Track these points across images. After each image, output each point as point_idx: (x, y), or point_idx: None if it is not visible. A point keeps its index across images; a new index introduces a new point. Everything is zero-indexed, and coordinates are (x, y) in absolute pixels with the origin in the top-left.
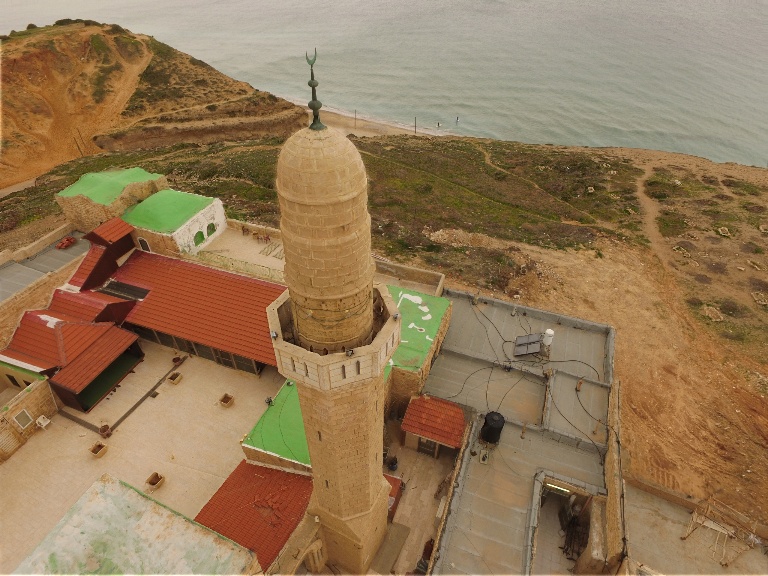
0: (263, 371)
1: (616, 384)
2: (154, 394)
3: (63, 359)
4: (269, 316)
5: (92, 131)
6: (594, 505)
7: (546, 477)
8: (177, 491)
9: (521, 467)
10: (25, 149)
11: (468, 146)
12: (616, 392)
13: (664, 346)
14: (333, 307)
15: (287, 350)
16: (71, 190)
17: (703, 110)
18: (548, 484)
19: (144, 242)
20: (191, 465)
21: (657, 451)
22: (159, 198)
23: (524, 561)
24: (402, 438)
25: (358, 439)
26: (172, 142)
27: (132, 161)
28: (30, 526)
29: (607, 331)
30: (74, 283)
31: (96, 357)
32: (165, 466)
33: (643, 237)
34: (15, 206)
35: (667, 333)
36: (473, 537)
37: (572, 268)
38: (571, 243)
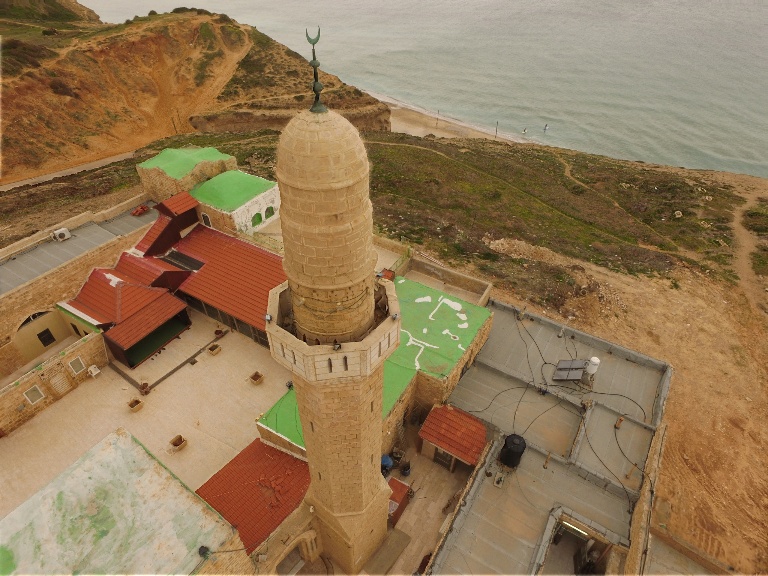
0: None
1: (662, 428)
2: (193, 361)
3: (118, 316)
4: (270, 299)
5: (189, 112)
6: (613, 555)
7: (563, 514)
8: (196, 456)
9: (537, 498)
10: (131, 124)
11: (549, 156)
12: (660, 437)
13: (735, 396)
14: (324, 297)
15: (277, 335)
16: (151, 162)
17: None
18: (565, 522)
19: (206, 217)
20: (213, 434)
21: (705, 510)
22: (225, 177)
23: None
24: (419, 445)
25: (350, 437)
26: (259, 128)
27: (219, 142)
28: (66, 463)
29: (664, 369)
30: (140, 248)
31: (147, 319)
32: (190, 430)
33: (731, 272)
34: (113, 174)
35: (741, 382)
36: (471, 561)
37: (641, 296)
38: (644, 269)
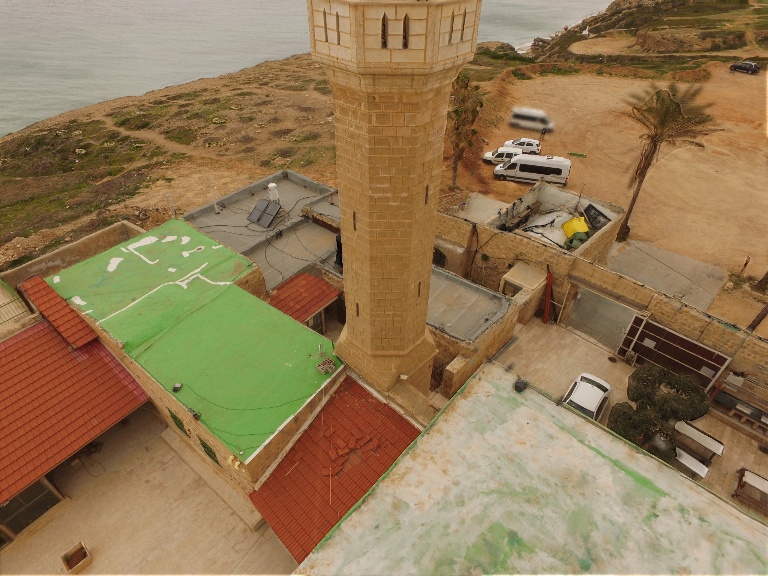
0: (61, 490)
1: None
2: None
3: None
4: (373, 1)
5: None
6: None
7: None
8: None
9: None
10: None
11: None
12: None
13: None
14: None
15: None
16: None
17: (73, 69)
18: None
19: None
20: None
21: None
22: None
23: (457, 283)
24: None
25: None
26: None
27: None
28: None
29: (284, 175)
30: None
31: None
32: None
33: (176, 154)
34: None
35: None
36: (430, 305)
37: (166, 198)
38: (136, 186)
